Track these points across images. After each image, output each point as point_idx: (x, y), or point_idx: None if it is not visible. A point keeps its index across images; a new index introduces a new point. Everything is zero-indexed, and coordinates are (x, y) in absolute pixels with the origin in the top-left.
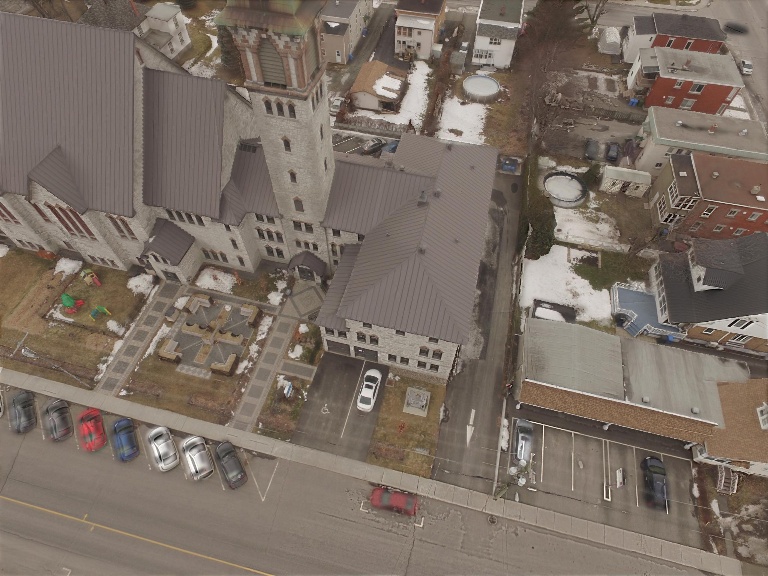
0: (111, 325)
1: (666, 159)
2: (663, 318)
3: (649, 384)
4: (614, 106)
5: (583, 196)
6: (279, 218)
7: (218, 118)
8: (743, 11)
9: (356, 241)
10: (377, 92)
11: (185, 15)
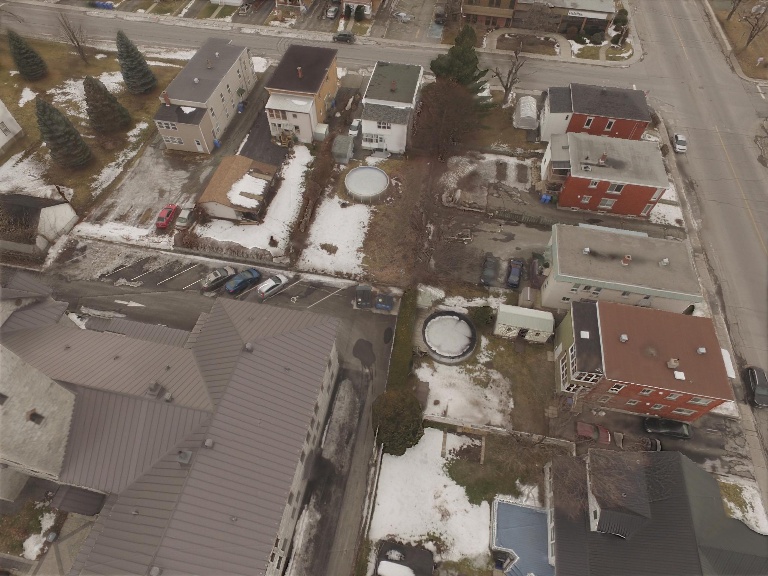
0: None
1: (573, 294)
2: (552, 562)
3: None
4: (523, 204)
5: (470, 349)
6: (2, 467)
7: None
8: (679, 66)
9: None
10: (232, 201)
11: (30, 88)
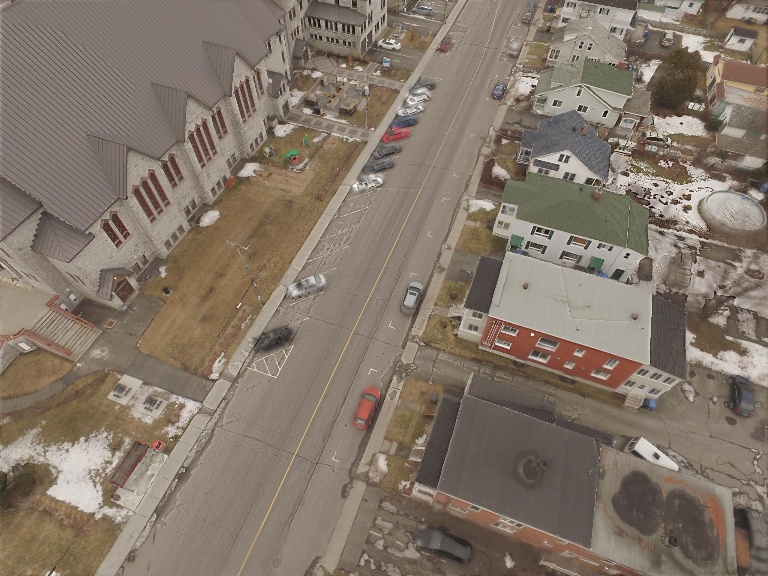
0: (317, 140)
1: None
2: None
3: None
4: None
5: None
6: None
7: None
8: None
9: (307, 5)
10: None
11: None
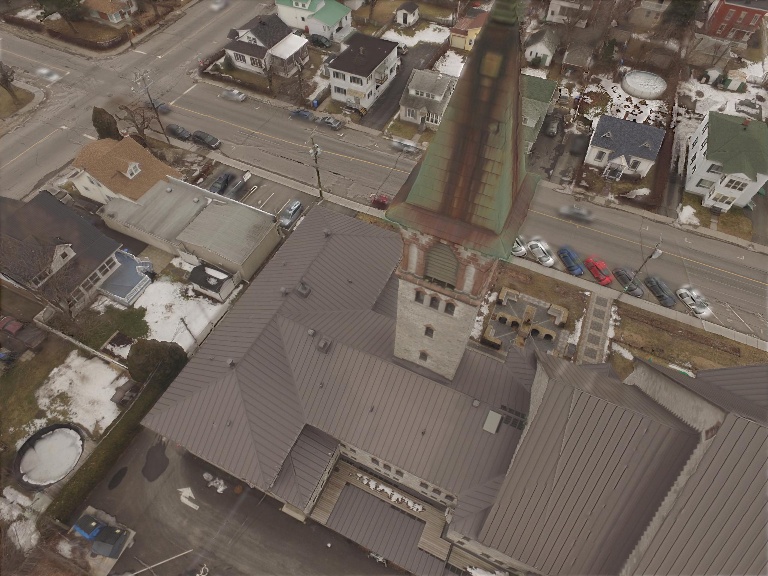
0: (628, 354)
1: None
2: None
3: (184, 210)
4: None
5: (43, 430)
6: None
7: (554, 371)
8: None
9: None
10: None
11: None
